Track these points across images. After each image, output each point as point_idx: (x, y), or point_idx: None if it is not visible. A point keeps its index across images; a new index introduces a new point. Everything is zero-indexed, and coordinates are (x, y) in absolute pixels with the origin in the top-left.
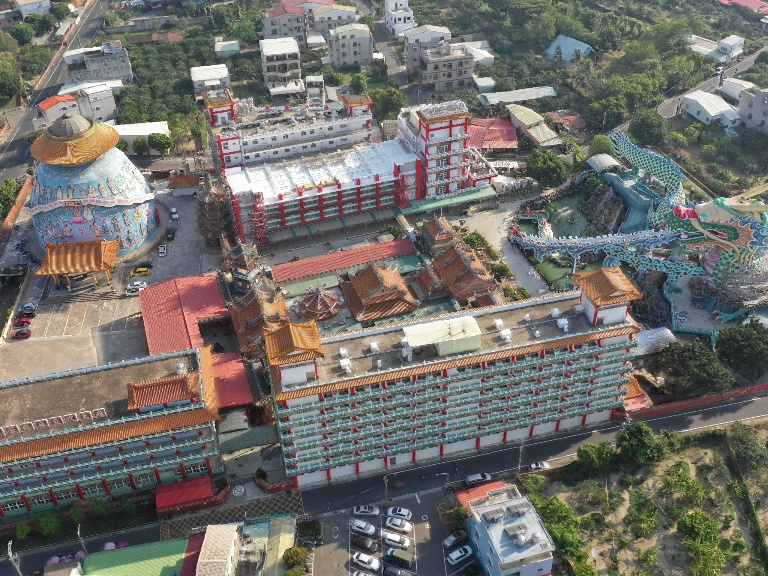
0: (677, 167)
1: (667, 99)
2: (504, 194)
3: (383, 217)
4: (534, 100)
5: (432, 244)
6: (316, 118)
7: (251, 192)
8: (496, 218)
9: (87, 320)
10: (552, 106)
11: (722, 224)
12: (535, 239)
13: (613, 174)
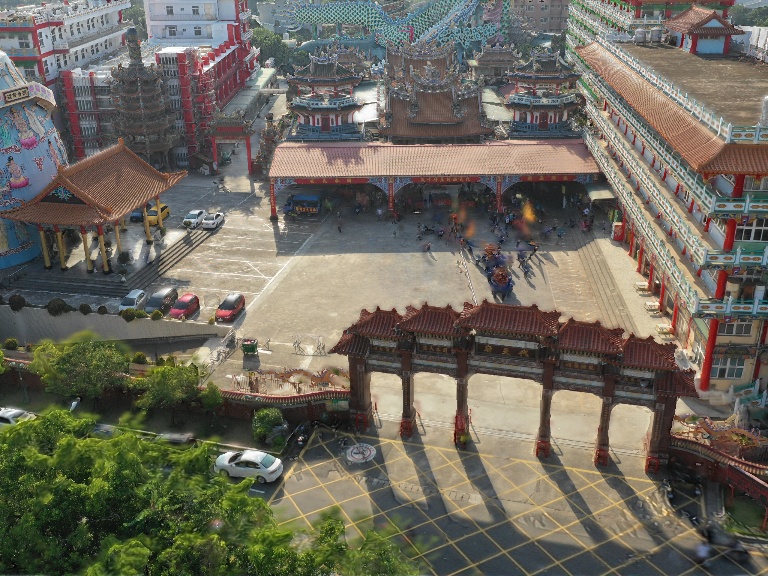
0: (369, 2)
1: None
2: None
3: (255, 94)
4: None
5: (363, 66)
6: (83, 8)
7: (191, 50)
8: None
9: (247, 258)
10: None
11: None
12: None
13: None
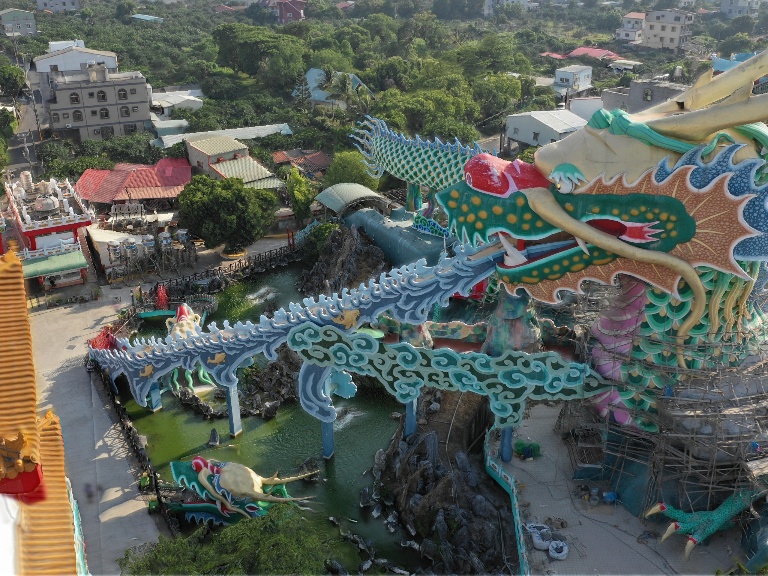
0: None
1: (484, 137)
2: (118, 269)
3: None
4: (250, 140)
5: None
6: None
7: None
8: (80, 318)
9: None
10: (279, 144)
11: (631, 191)
12: (140, 350)
13: (364, 208)
